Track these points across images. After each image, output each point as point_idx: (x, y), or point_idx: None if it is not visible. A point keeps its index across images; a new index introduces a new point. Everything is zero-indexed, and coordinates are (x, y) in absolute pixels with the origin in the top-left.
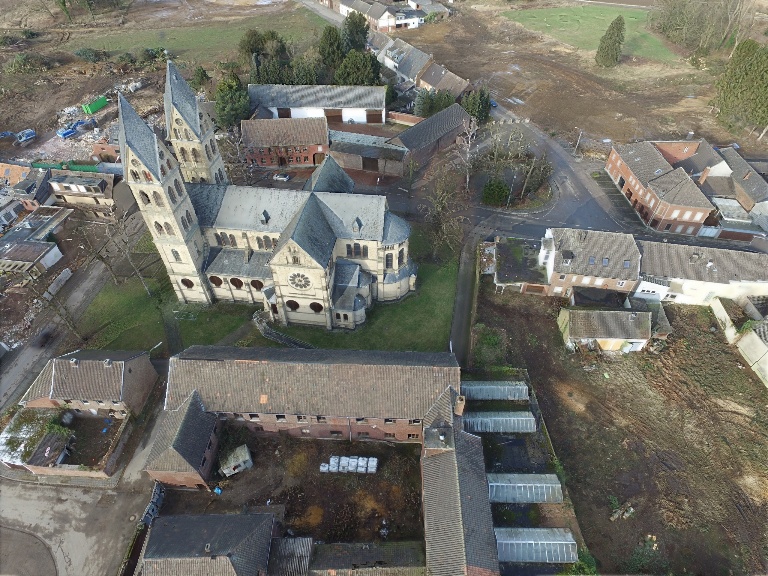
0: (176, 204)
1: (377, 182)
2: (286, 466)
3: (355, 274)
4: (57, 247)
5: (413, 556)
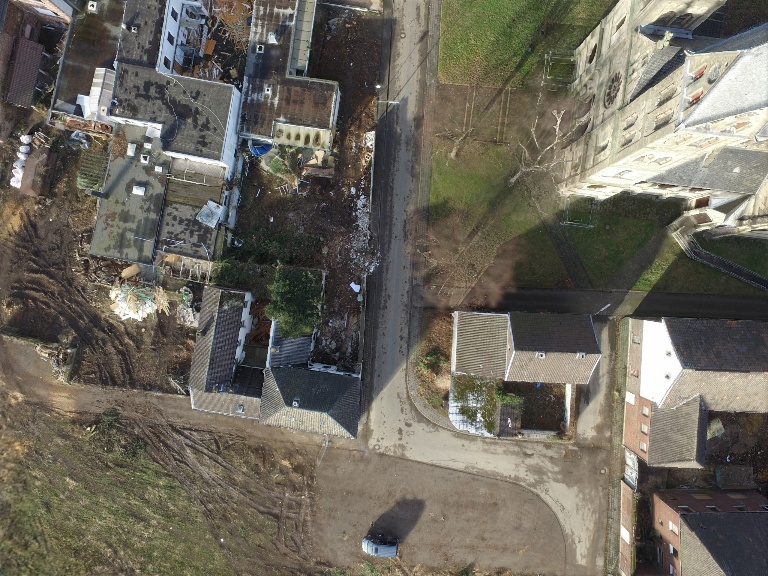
0: None
1: None
2: (741, 423)
3: None
4: (338, 86)
5: None
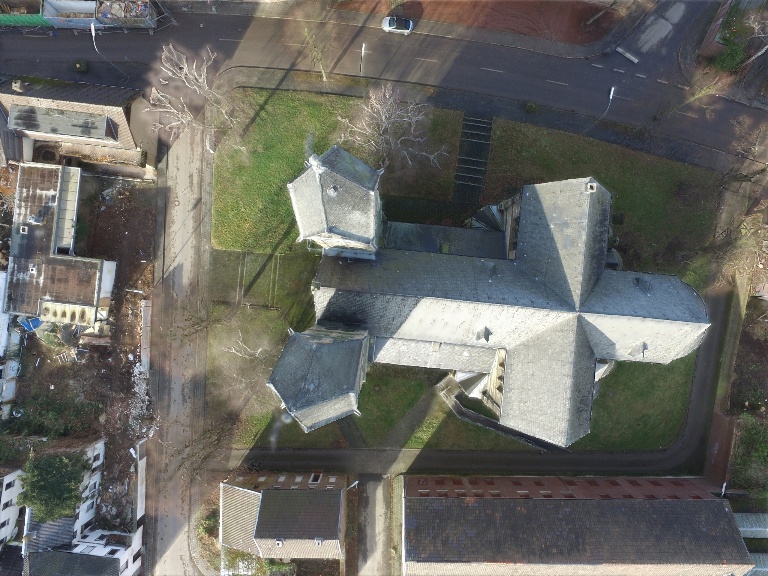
0: None
1: (609, 100)
2: None
3: (599, 372)
4: (105, 261)
5: None
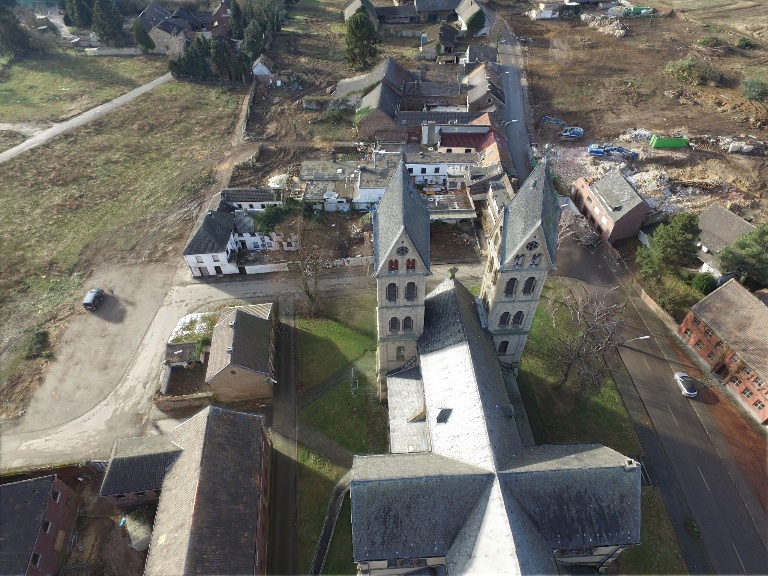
0: (394, 303)
1: None
2: None
3: None
4: None
5: None
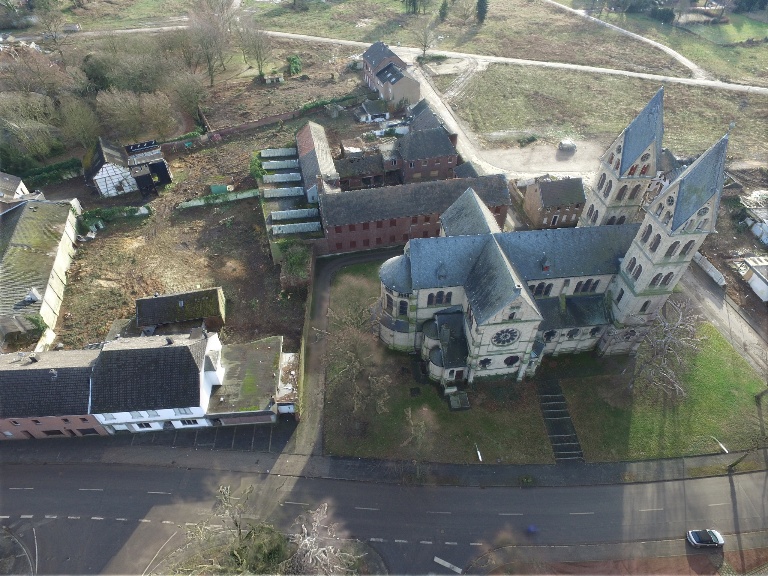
0: None
1: None
2: None
3: None
4: None
5: (339, 167)
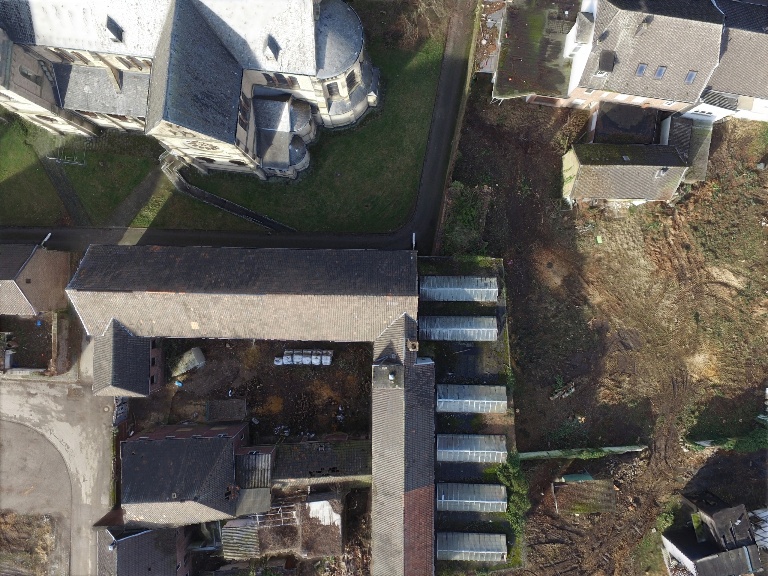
0: None
1: None
2: (240, 358)
3: (284, 115)
4: None
5: (362, 461)
